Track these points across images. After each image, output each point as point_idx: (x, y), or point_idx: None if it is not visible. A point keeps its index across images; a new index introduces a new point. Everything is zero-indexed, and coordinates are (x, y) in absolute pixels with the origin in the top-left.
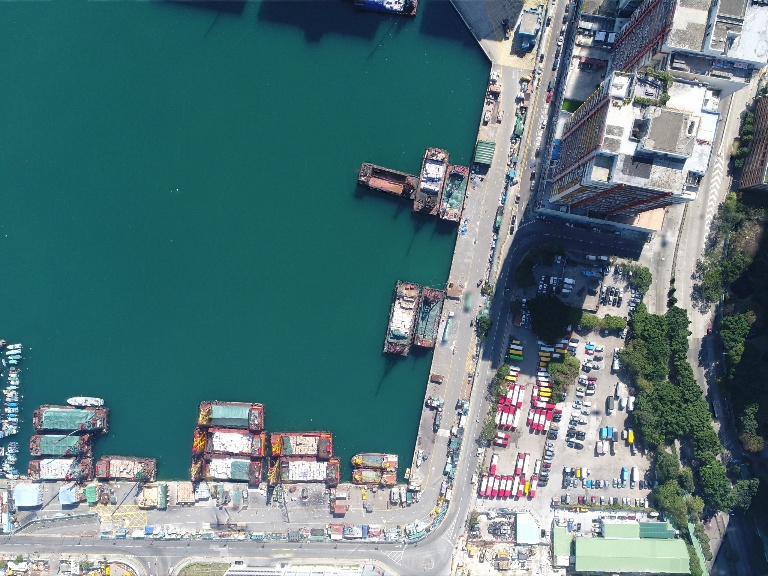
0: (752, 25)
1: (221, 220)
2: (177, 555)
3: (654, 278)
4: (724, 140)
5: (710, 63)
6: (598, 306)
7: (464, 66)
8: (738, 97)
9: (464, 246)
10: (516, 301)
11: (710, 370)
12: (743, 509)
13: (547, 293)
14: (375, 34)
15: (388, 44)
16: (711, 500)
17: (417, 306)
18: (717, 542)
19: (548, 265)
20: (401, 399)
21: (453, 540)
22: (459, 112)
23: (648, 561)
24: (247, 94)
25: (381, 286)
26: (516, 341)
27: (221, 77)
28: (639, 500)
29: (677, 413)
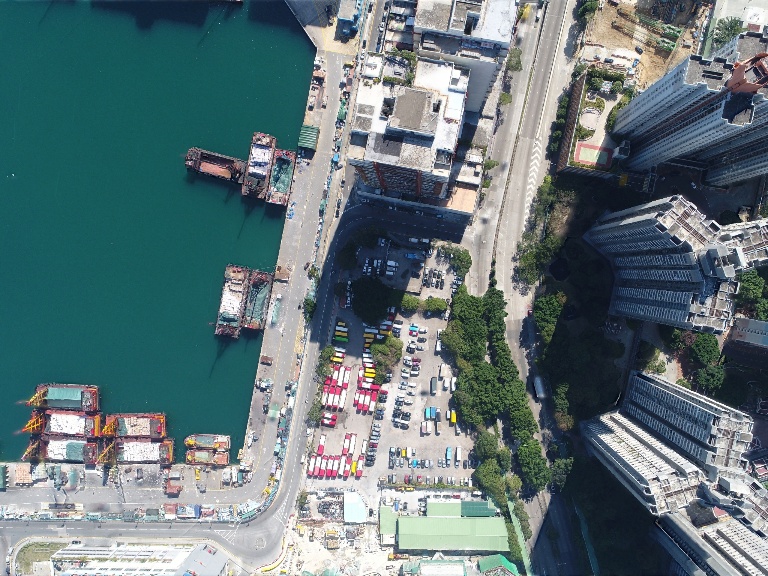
0: (496, 5)
1: (57, 205)
2: (16, 535)
3: (476, 260)
4: (542, 124)
5: (460, 43)
6: (421, 288)
7: (291, 52)
8: (555, 82)
9: (291, 229)
10: (339, 283)
11: (531, 351)
12: (559, 487)
13: (372, 275)
14: (205, 21)
15: (217, 30)
16: (526, 478)
17: (247, 289)
18: (539, 520)
19: (371, 248)
20: (234, 381)
21: (284, 519)
22: (286, 97)
23: (468, 539)
24: (80, 80)
25: (213, 269)
26: (342, 323)
27: (55, 63)
28: (463, 479)
29: (491, 393)
